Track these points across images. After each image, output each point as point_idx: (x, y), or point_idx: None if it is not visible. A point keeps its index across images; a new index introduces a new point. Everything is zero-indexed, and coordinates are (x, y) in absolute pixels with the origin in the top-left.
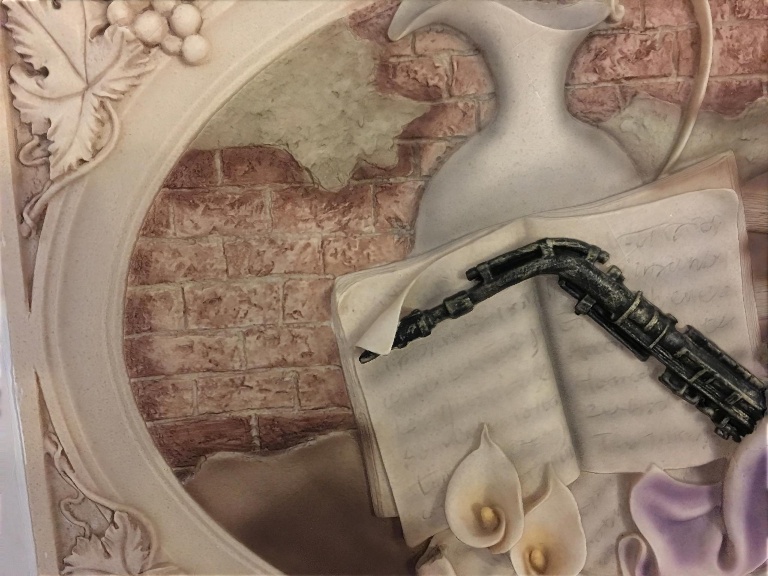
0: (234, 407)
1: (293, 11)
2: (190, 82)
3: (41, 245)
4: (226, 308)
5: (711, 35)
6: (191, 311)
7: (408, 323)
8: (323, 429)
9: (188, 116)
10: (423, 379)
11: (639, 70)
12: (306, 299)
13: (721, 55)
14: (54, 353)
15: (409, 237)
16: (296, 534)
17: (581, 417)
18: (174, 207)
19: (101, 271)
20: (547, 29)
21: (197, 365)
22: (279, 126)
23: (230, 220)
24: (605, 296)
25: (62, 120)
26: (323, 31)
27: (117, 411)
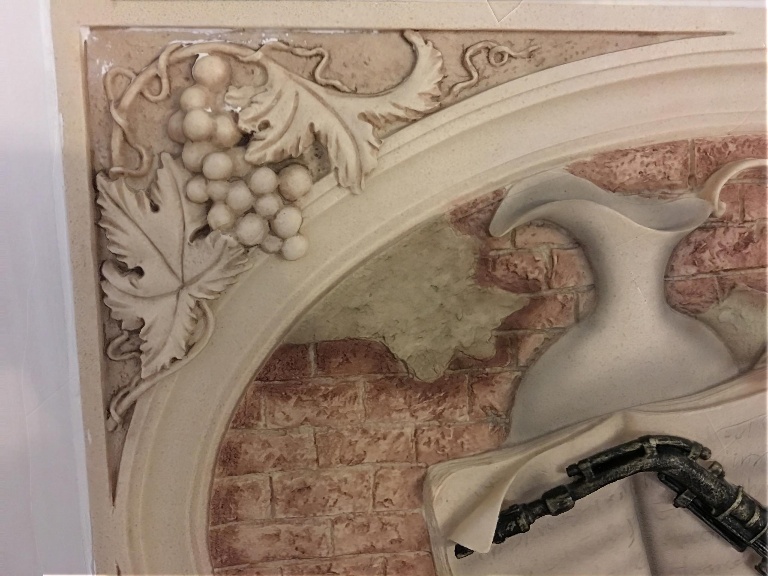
0: None
1: (393, 206)
2: (285, 275)
3: (128, 441)
4: (315, 497)
5: None
6: (279, 500)
7: (507, 520)
8: None
9: (282, 308)
10: (517, 568)
11: (737, 262)
12: (397, 487)
13: None
14: (136, 546)
15: (504, 426)
16: None
17: None
18: (266, 399)
19: (187, 461)
20: (653, 231)
21: (283, 553)
22: (376, 320)
23: (322, 411)
24: (707, 494)
25: (156, 320)
26: (424, 228)
27: None
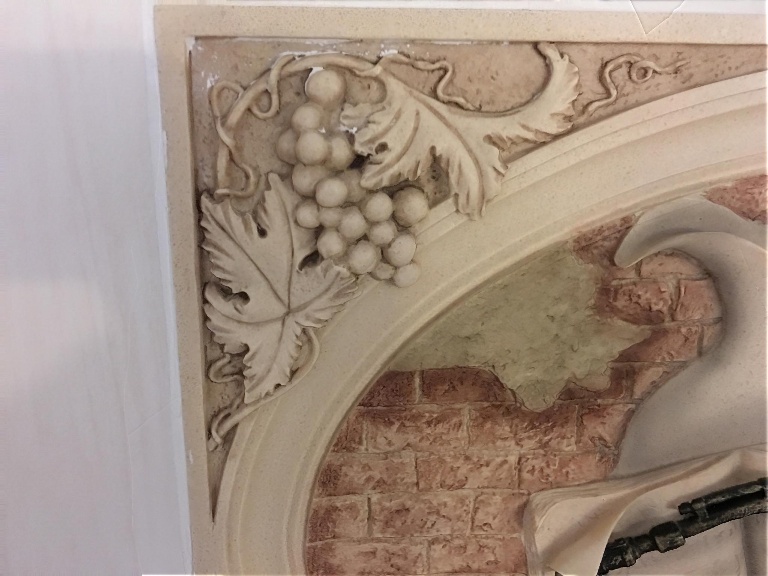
0: None
1: (511, 231)
2: (393, 300)
3: (229, 462)
4: (413, 518)
5: None
6: (377, 521)
7: (612, 554)
8: None
9: (388, 334)
10: None
11: None
12: (497, 513)
13: None
14: (235, 559)
15: (612, 457)
16: None
17: None
18: (368, 424)
19: (285, 480)
20: None
21: (378, 569)
22: (487, 349)
23: (425, 437)
24: None
25: (261, 347)
26: (545, 257)
27: None
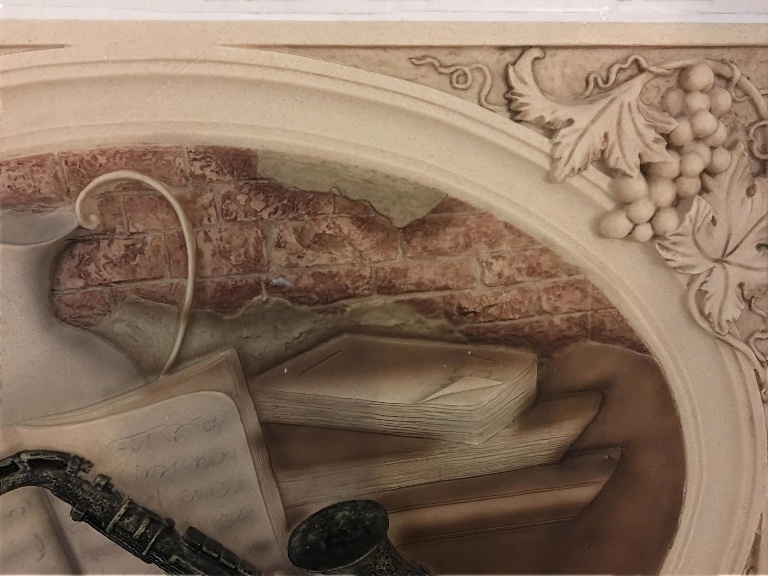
0: None
1: None
2: None
3: None
4: None
5: (187, 243)
6: None
7: None
8: None
9: None
10: None
11: (127, 274)
12: None
13: (213, 256)
14: None
15: None
16: None
17: None
18: None
19: None
20: (3, 246)
21: None
22: None
23: None
24: (88, 507)
25: None
26: None
27: None
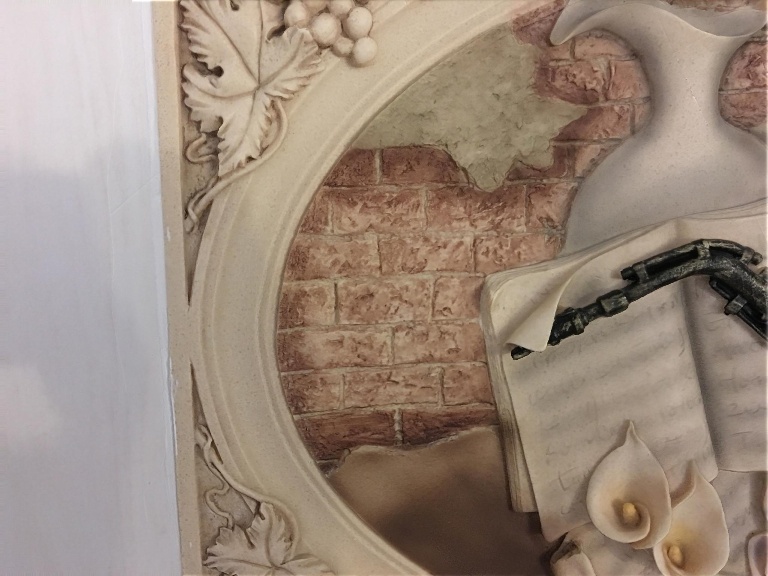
0: (379, 401)
1: (458, 15)
2: (354, 83)
3: (204, 240)
4: (377, 304)
5: None
6: (343, 307)
7: (563, 321)
8: (465, 424)
9: (350, 116)
10: (570, 376)
11: None
12: (456, 296)
13: None
14: (209, 346)
15: (560, 237)
16: (434, 528)
17: (722, 416)
18: (333, 205)
19: (257, 266)
20: (710, 35)
21: (346, 360)
22: (440, 127)
23: (386, 218)
24: (758, 297)
25: (234, 118)
26: (488, 35)
27: (265, 404)
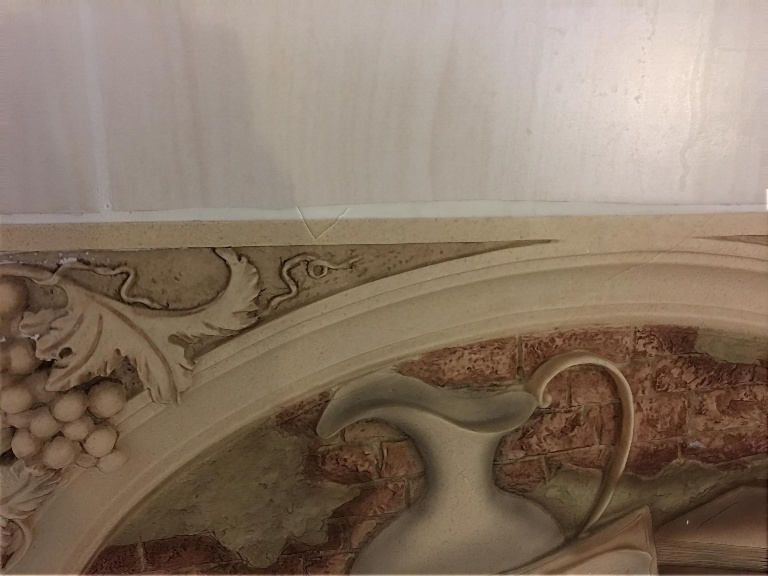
0: None
1: (216, 411)
2: (107, 479)
3: None
4: None
5: (632, 419)
6: None
7: None
8: None
9: (106, 510)
10: None
11: (564, 444)
12: None
13: (641, 425)
14: None
15: None
16: None
17: None
18: None
19: None
20: (476, 434)
21: None
22: (204, 518)
23: None
24: None
25: None
26: (249, 434)
27: None
